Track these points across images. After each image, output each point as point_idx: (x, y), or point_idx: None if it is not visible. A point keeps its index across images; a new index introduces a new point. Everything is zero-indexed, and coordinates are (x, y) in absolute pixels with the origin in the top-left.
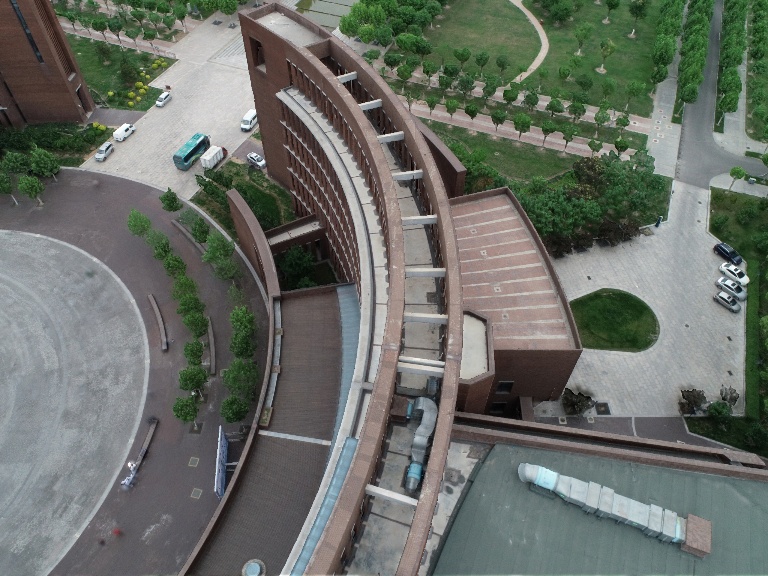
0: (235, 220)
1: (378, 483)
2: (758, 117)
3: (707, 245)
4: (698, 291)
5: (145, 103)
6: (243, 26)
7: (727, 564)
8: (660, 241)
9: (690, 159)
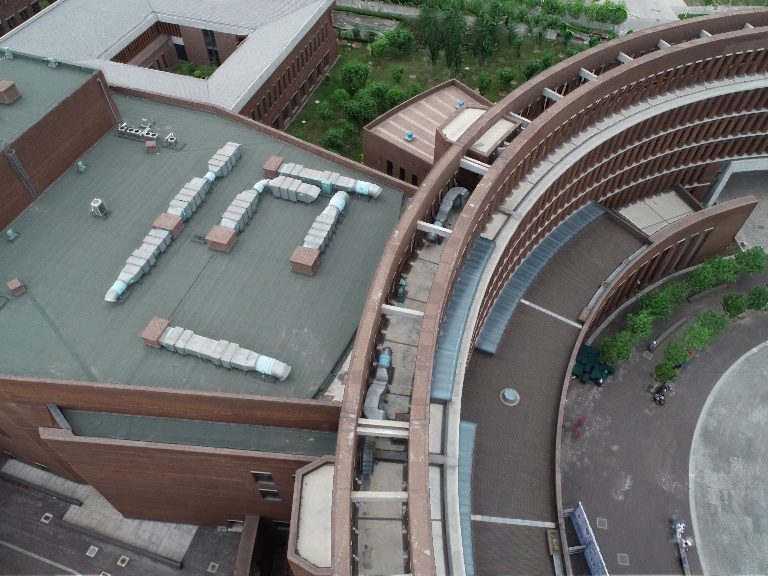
0: None
1: None
2: None
3: None
4: None
5: None
6: None
7: (140, 325)
8: None
9: None
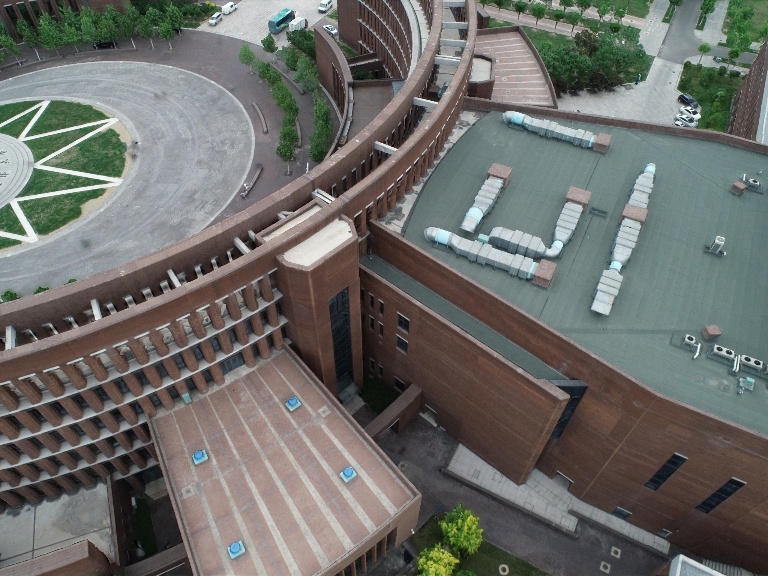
0: (318, 52)
1: (419, 123)
2: (731, 16)
3: (673, 97)
4: (660, 122)
5: None
6: None
7: (619, 158)
8: (637, 93)
9: (672, 45)
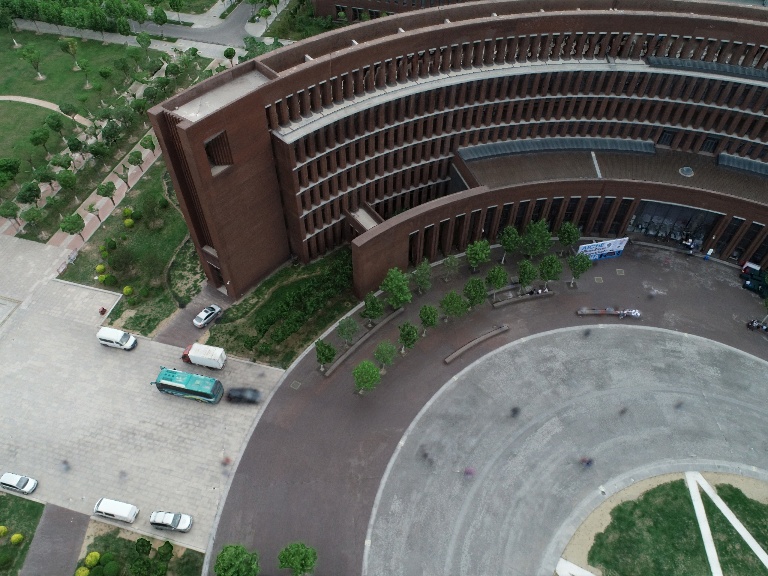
0: None
1: None
2: None
3: None
4: None
5: (14, 518)
6: (194, 140)
7: None
8: None
9: (226, 41)
